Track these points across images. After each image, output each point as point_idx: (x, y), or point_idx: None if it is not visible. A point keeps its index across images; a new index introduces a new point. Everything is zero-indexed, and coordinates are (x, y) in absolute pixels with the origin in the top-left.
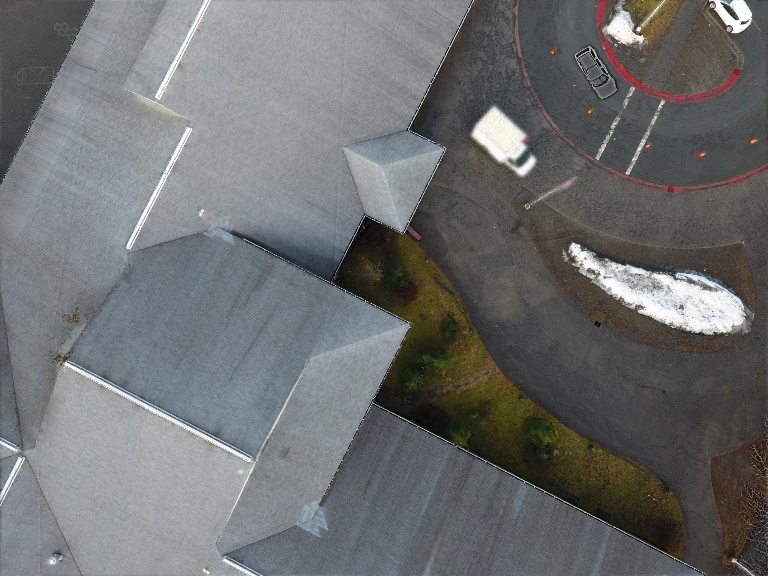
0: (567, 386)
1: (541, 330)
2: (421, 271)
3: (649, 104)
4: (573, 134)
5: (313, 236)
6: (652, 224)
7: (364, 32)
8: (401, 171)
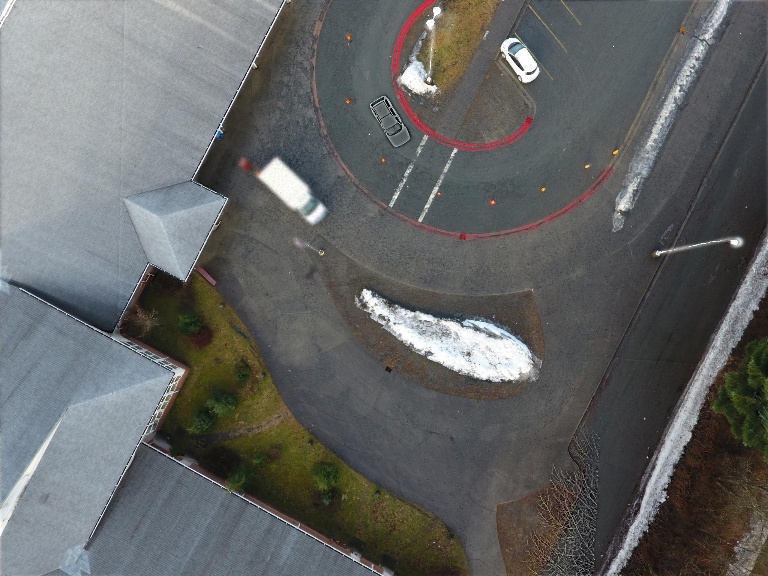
0: (357, 431)
1: (333, 375)
2: (217, 315)
3: (442, 152)
4: (367, 182)
5: (95, 284)
6: (443, 271)
7: (142, 88)
8: (180, 221)
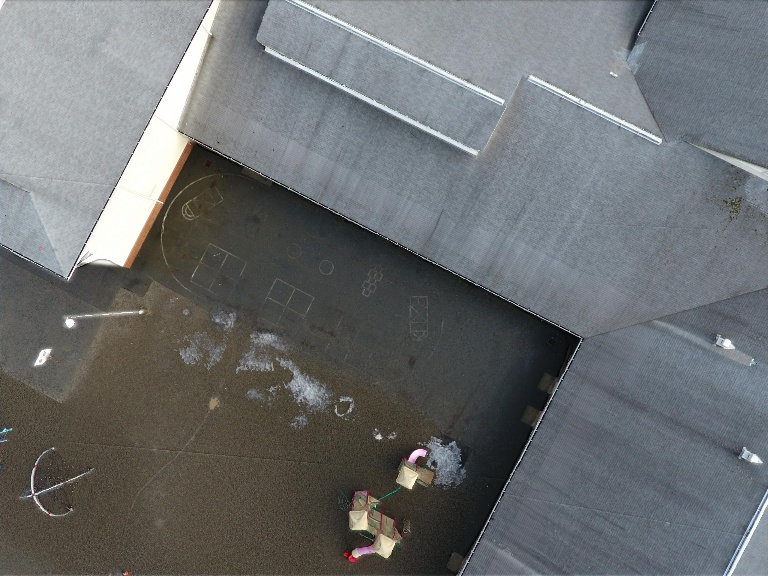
0: None
1: None
2: None
3: None
4: None
5: None
6: None
7: None
8: None
